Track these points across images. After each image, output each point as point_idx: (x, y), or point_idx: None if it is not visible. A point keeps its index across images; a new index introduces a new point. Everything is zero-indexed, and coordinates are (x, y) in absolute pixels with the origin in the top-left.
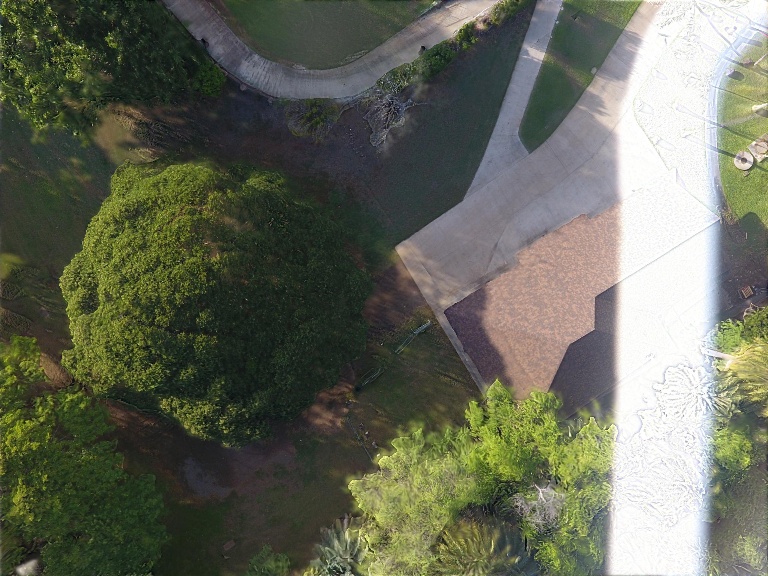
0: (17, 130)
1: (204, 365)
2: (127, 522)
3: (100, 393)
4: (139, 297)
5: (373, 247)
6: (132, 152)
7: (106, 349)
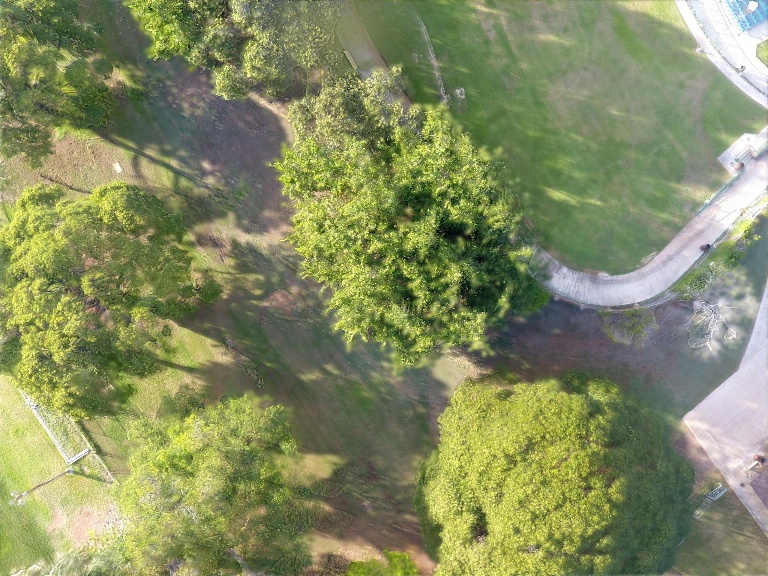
0: (328, 339)
1: None
2: None
3: None
4: (552, 532)
5: (664, 421)
6: (440, 353)
7: (510, 575)
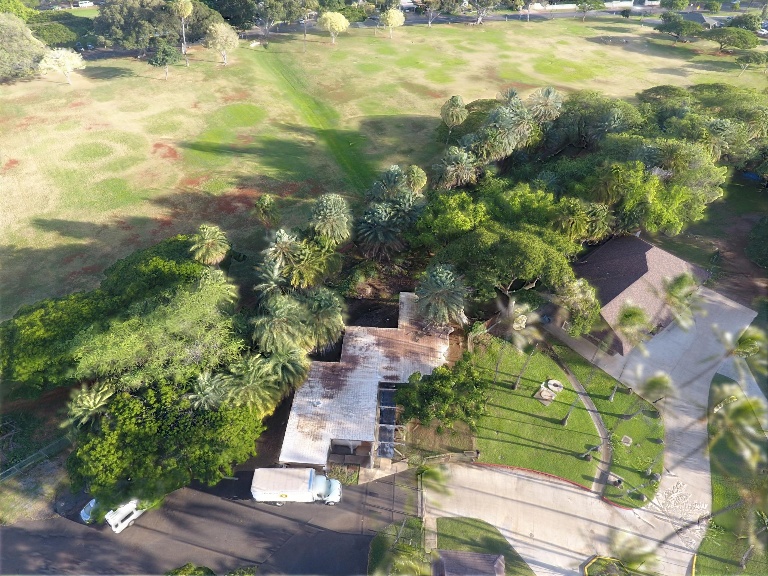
0: None
1: None
2: None
3: None
4: None
5: None
6: None
7: None
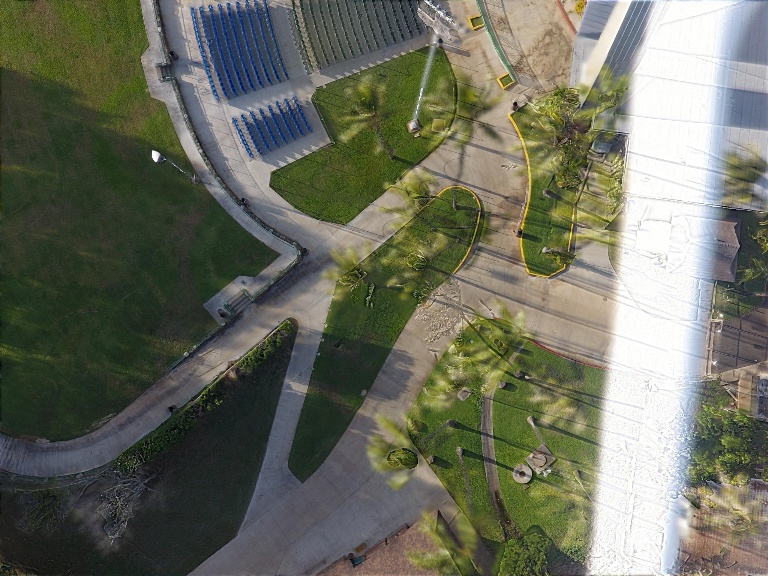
0: None
1: None
2: None
3: None
4: None
5: None
6: None
7: None
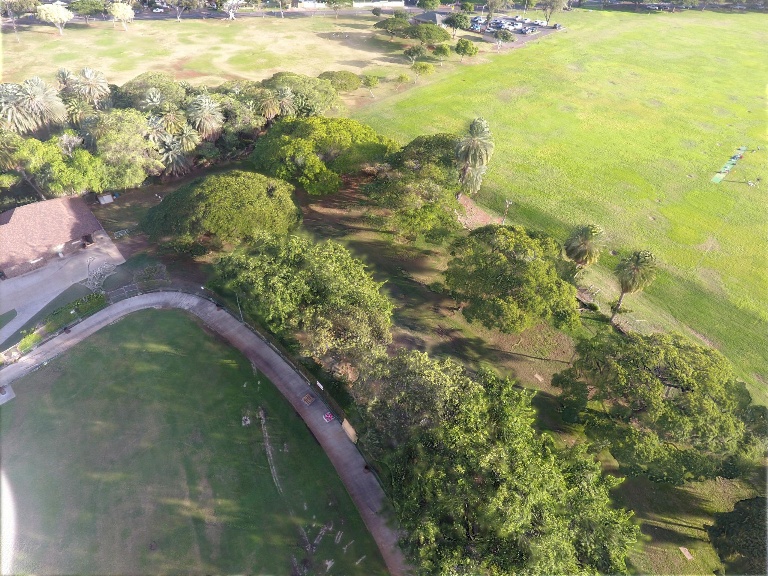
0: None
1: None
2: None
3: None
4: None
5: None
6: None
7: None
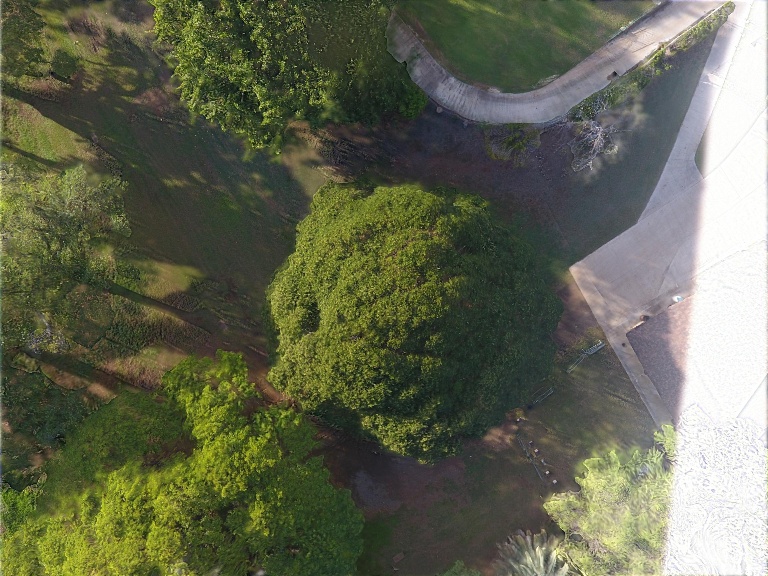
0: (199, 145)
1: (424, 386)
2: (338, 537)
3: (307, 409)
4: (376, 320)
5: (548, 268)
6: (315, 170)
7: (332, 369)
